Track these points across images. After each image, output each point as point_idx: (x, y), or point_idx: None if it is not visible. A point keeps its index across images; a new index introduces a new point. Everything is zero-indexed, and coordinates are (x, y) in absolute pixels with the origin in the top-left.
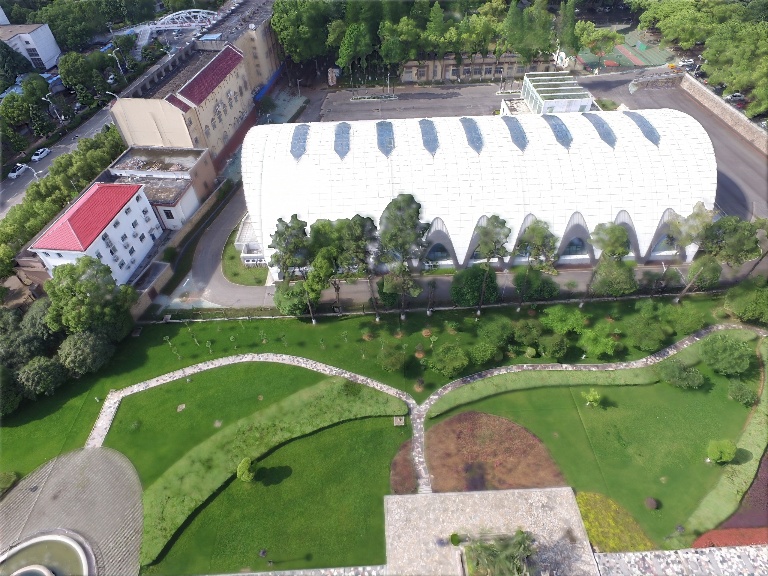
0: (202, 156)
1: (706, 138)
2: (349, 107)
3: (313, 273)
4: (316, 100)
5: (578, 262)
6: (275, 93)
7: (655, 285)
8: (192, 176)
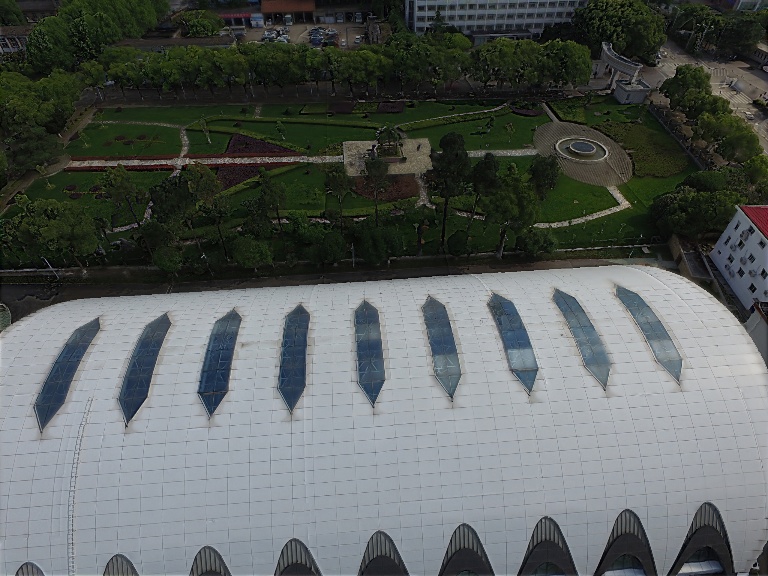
0: None
1: (8, 331)
2: None
3: None
4: None
5: None
6: None
7: None
8: None
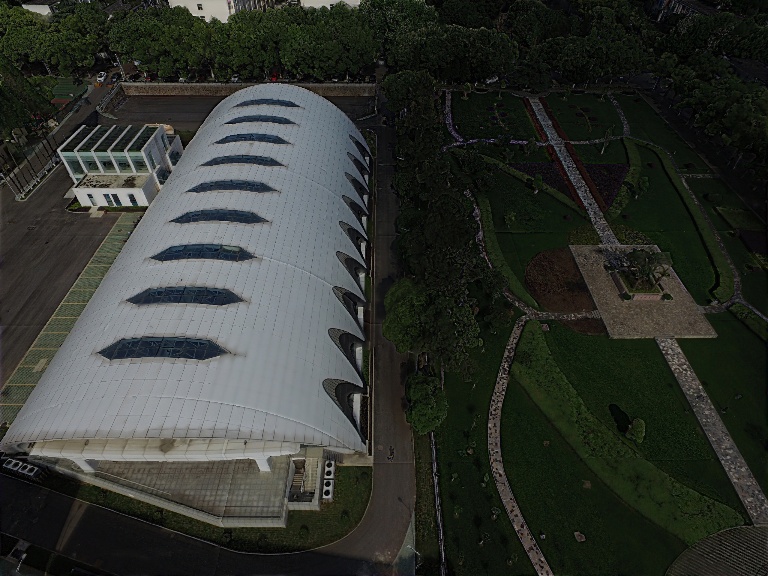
0: None
1: (299, 88)
2: None
3: (474, 323)
4: None
5: None
6: None
7: None
8: None
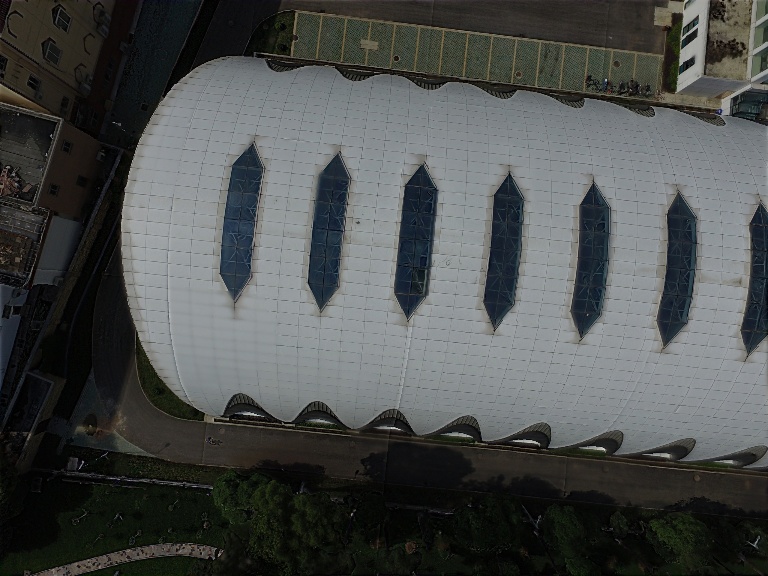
0: (54, 148)
1: None
2: None
3: None
4: None
5: None
6: None
7: None
8: (46, 201)
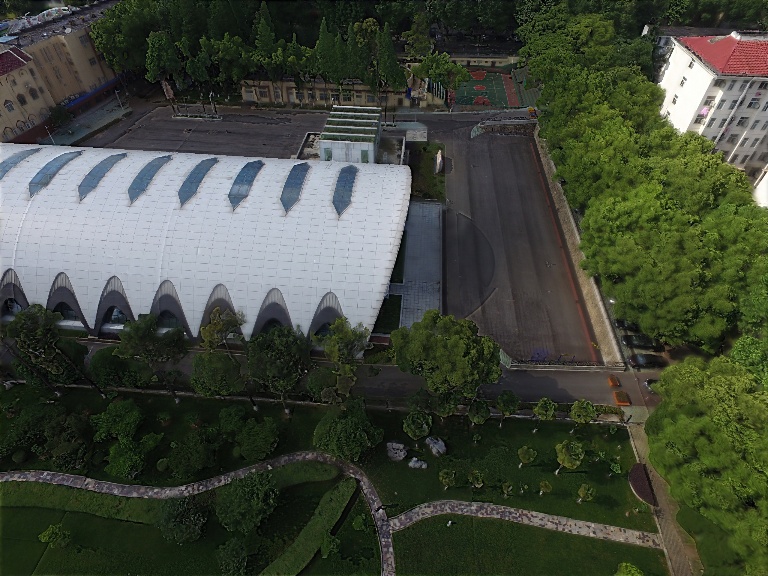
0: None
1: (403, 211)
2: (163, 124)
3: None
4: (138, 113)
5: (230, 341)
6: (105, 102)
7: (265, 388)
8: None
